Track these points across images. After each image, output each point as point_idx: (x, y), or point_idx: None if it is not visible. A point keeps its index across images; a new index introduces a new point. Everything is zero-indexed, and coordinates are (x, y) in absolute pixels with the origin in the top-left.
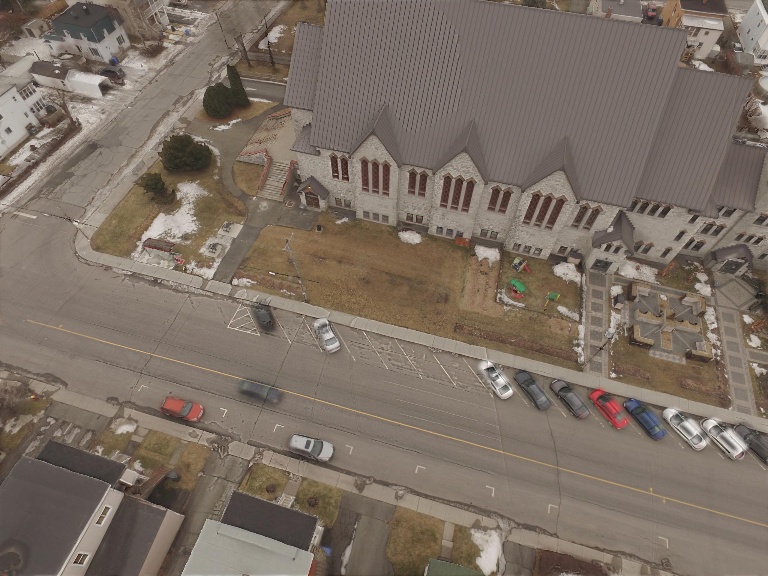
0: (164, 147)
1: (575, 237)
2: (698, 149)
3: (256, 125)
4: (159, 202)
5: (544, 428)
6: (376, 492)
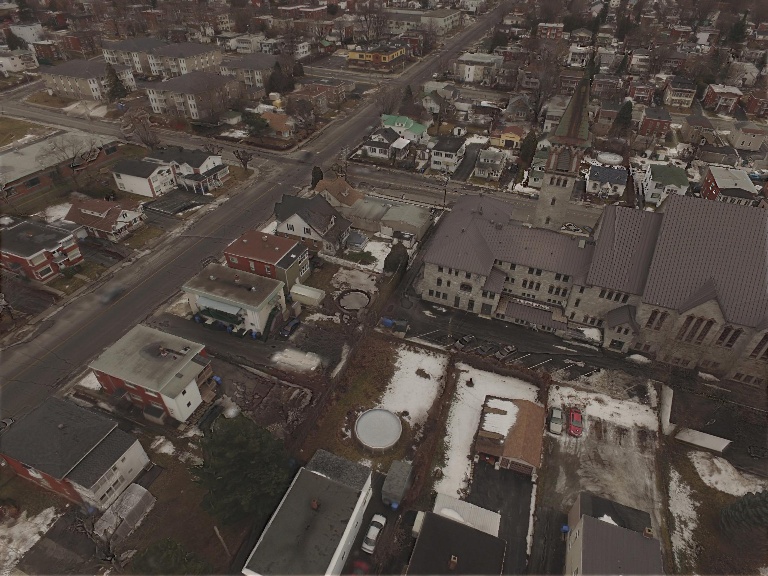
0: None
1: None
2: None
3: None
4: None
5: None
6: None
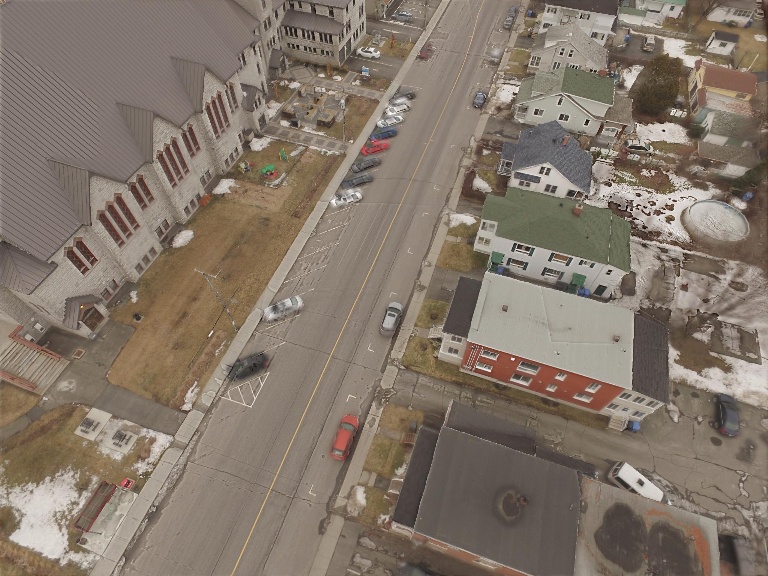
0: None
1: (237, 120)
2: (213, 8)
3: None
4: None
5: (385, 181)
6: (426, 278)
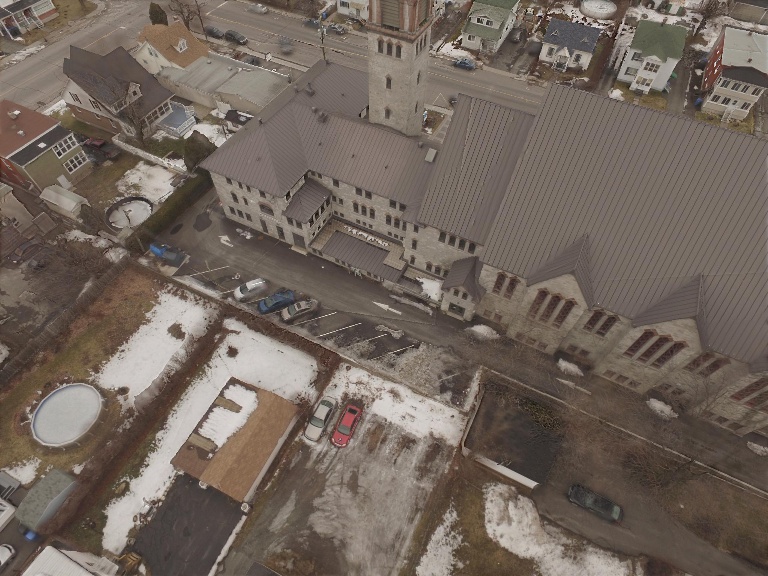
0: None
1: None
2: None
3: None
4: None
5: None
6: None
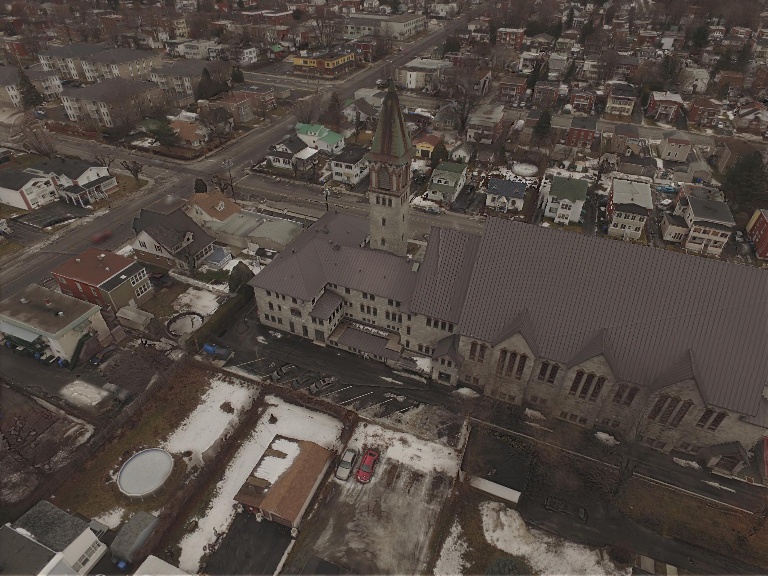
0: None
1: None
2: None
3: None
4: None
5: None
6: None
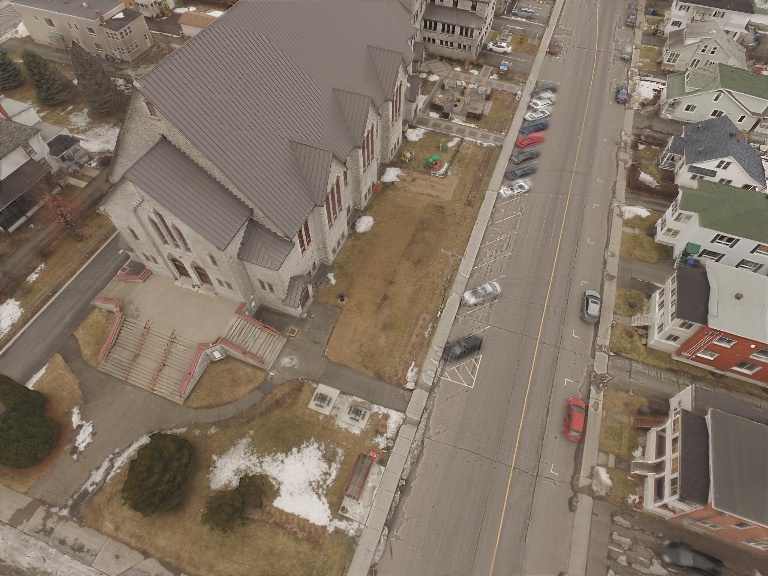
0: (137, 505)
1: None
2: None
3: (104, 382)
4: (259, 503)
5: (548, 173)
6: (613, 268)
